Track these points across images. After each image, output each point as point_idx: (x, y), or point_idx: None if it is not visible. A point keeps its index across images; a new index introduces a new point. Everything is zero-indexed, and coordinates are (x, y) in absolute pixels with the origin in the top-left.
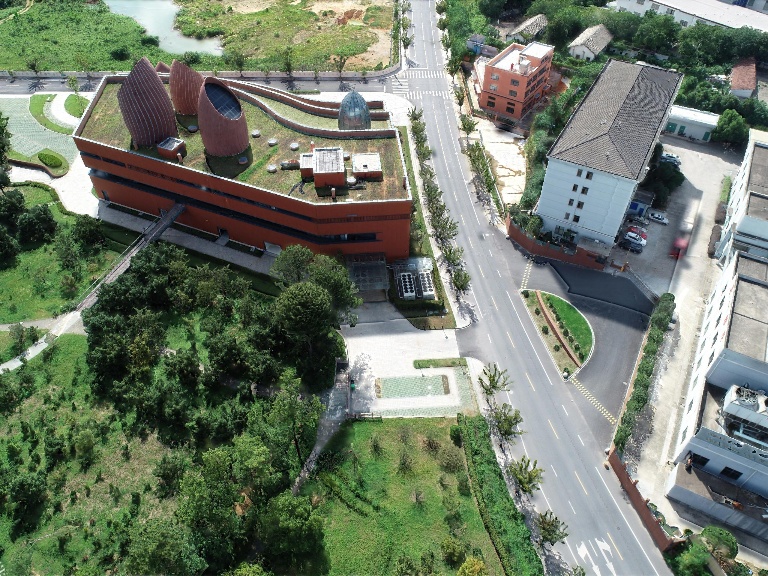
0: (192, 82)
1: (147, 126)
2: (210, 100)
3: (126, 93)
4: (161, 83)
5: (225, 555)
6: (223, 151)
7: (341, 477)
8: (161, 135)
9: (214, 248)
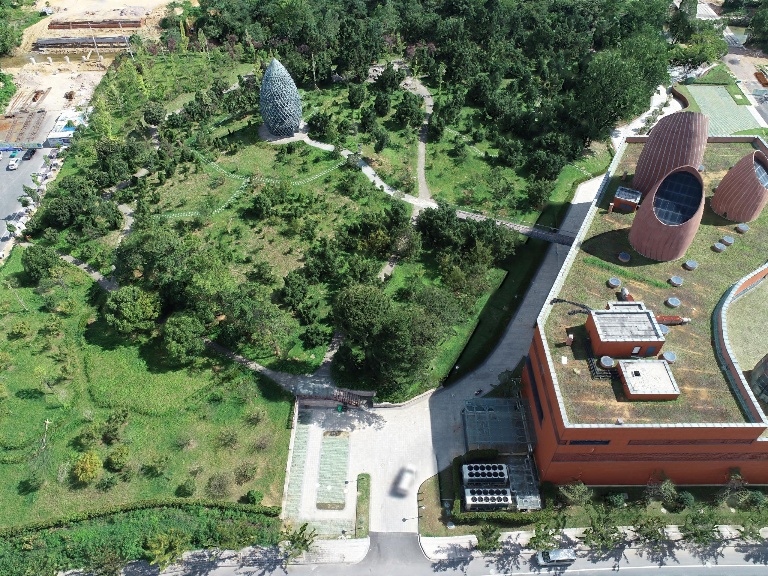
0: (741, 182)
1: (641, 169)
2: (668, 186)
3: (654, 129)
4: (690, 148)
5: (175, 301)
6: (632, 236)
7: (230, 385)
8: (645, 187)
9: (543, 289)
